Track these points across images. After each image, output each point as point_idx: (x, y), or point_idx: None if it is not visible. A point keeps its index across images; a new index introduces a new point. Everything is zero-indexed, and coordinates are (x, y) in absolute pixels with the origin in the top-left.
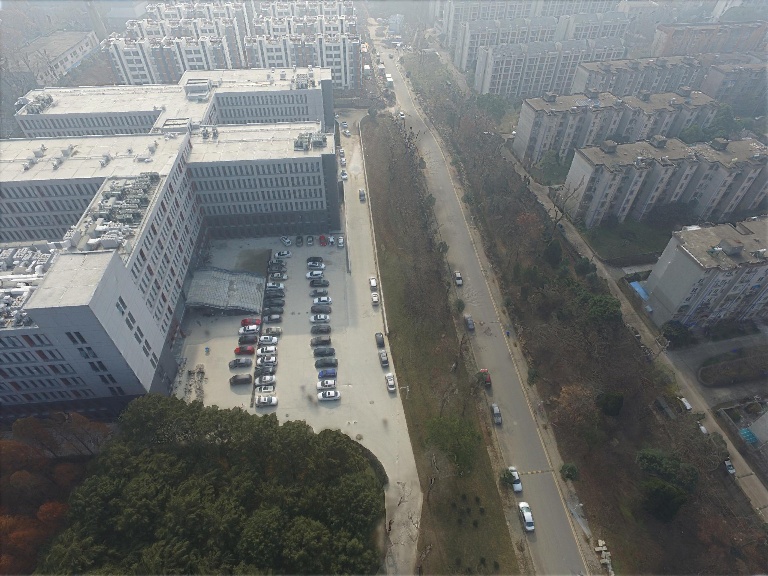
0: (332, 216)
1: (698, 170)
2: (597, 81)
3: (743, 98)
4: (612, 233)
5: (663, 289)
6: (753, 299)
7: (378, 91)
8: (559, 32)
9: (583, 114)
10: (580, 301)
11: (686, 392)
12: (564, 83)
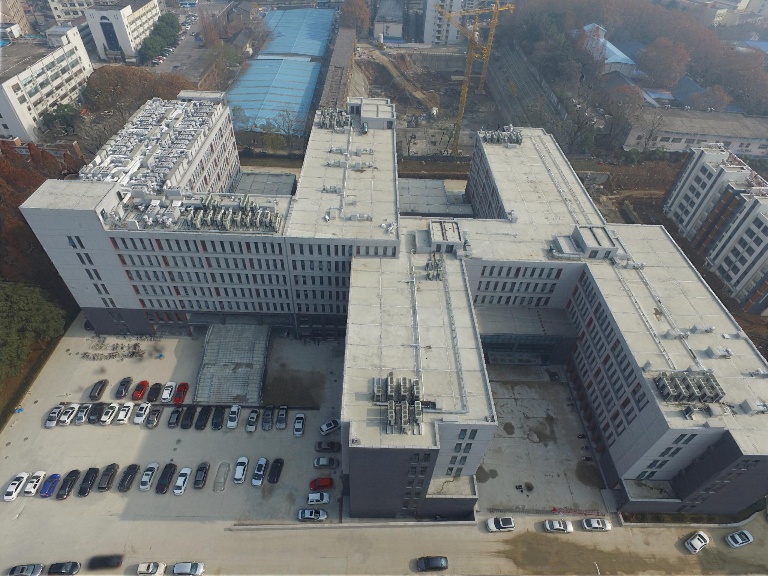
0: None
1: None
2: None
3: None
4: None
5: None
6: None
7: None
8: None
9: None
10: None
11: None
12: None
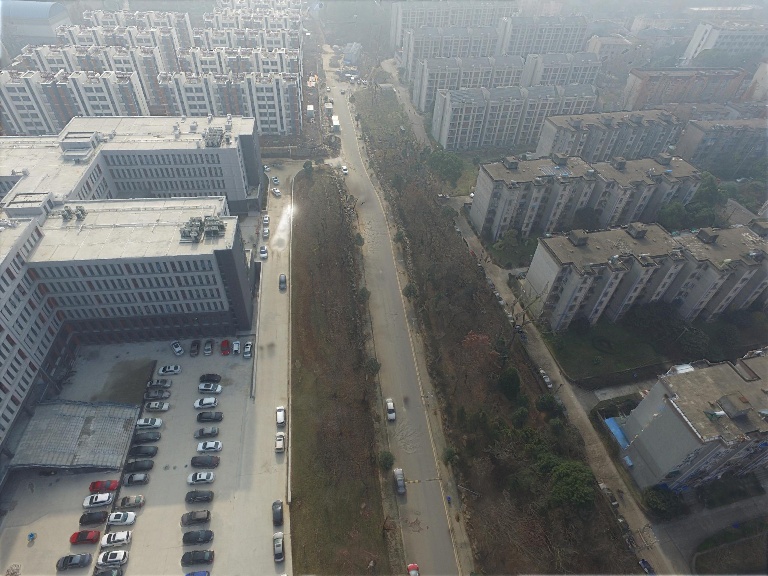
0: (238, 316)
1: (684, 268)
2: (566, 138)
3: (723, 157)
4: (582, 340)
5: (646, 444)
6: (758, 456)
7: (320, 138)
8: (526, 72)
9: (549, 184)
10: (541, 469)
11: None
12: (531, 132)
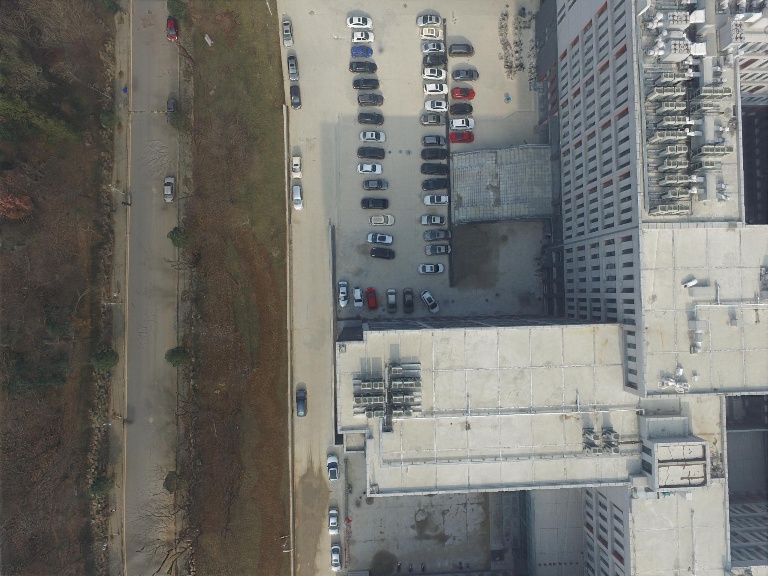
0: None
1: None
2: None
3: None
4: None
5: None
6: None
7: None
8: None
9: None
10: None
11: None
12: None
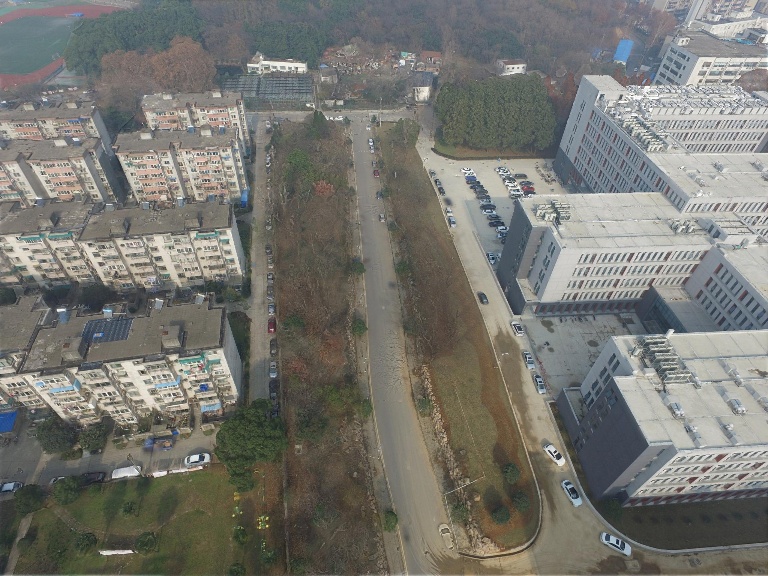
0: None
1: None
2: None
3: None
4: None
5: None
6: None
7: None
8: None
9: None
10: None
11: (260, 168)
12: None
